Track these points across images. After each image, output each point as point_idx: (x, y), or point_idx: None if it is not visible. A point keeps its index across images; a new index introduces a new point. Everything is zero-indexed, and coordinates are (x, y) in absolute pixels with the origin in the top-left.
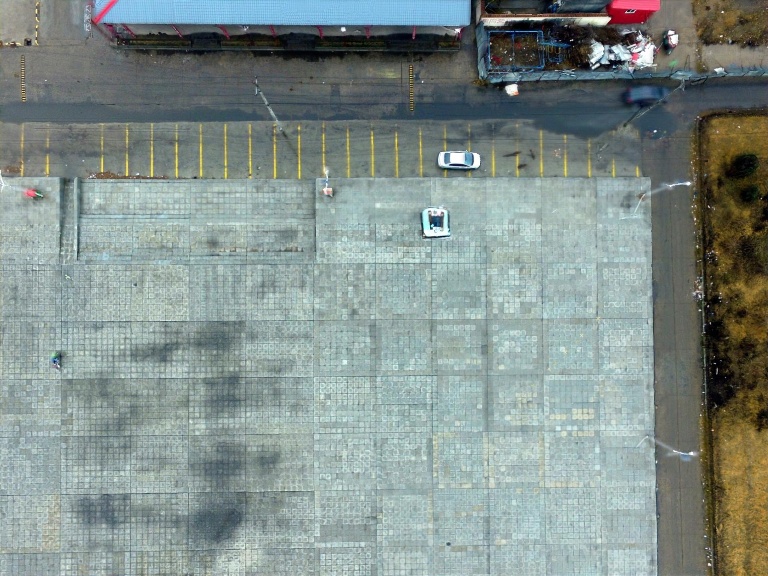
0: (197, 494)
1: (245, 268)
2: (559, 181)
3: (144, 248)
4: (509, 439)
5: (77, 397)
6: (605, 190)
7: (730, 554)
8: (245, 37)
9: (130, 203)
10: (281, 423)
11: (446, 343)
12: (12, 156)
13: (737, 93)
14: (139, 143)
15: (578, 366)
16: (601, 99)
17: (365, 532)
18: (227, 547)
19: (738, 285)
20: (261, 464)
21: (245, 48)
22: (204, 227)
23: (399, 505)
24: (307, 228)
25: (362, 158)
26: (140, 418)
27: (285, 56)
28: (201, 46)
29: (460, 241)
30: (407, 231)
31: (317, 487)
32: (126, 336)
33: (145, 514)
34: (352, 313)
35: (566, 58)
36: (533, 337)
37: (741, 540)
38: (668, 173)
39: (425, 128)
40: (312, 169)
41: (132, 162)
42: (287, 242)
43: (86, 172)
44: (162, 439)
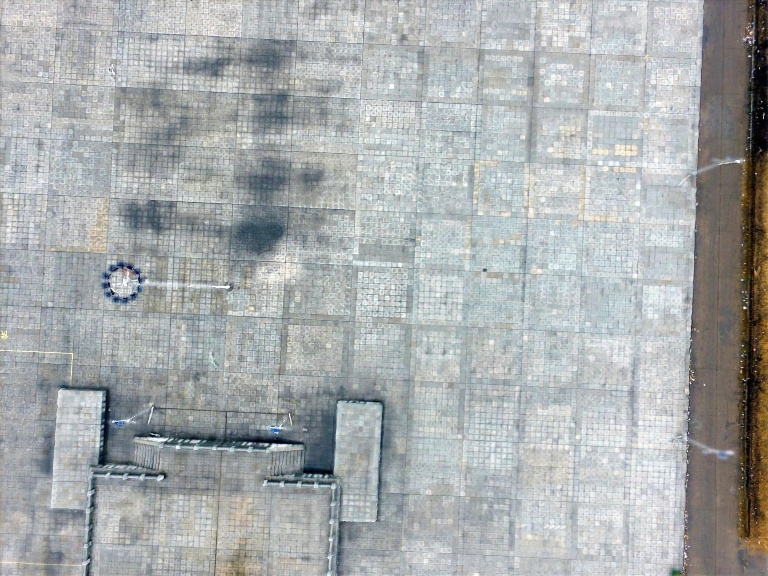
0: (241, 206)
1: None
2: None
3: None
4: (550, 171)
5: (130, 105)
6: None
7: (767, 297)
8: None
9: None
10: (326, 142)
11: (493, 73)
12: None
13: None
14: None
15: (623, 103)
16: None
17: (403, 253)
18: (268, 259)
19: None
20: (305, 181)
21: None
22: None
23: (438, 229)
24: None
25: None
26: (189, 129)
27: None
28: None
29: None
30: None
31: (358, 206)
32: (180, 49)
33: (190, 222)
34: (401, 38)
35: None
36: (580, 72)
37: None
38: None
39: None
40: None
41: None
42: None
43: None
44: (210, 151)
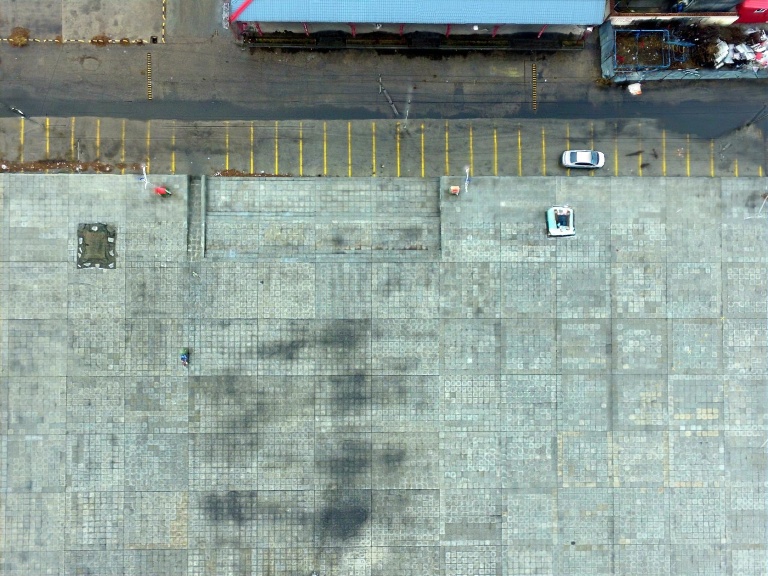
0: (323, 491)
1: (371, 266)
2: (684, 180)
3: (270, 246)
4: (633, 438)
5: (204, 394)
6: (730, 190)
7: None
8: (370, 35)
9: (255, 201)
10: (406, 421)
11: (571, 342)
12: (138, 153)
13: None
14: (264, 141)
15: (702, 366)
16: (724, 98)
17: (490, 530)
18: (353, 544)
19: None
20: (386, 462)
21: (369, 46)
22: (329, 225)
23: (524, 504)
24: (432, 226)
25: (485, 157)
26: (267, 415)
27: (409, 54)
28: (326, 44)
29: (585, 240)
30: (532, 230)
31: (442, 485)
32: (253, 333)
33: (272, 511)
34: (477, 311)
35: (689, 57)
36: (657, 336)
37: None
38: None
39: (548, 127)
40: (435, 167)
41: (257, 160)
42: (412, 240)
43: (211, 169)
44: (288, 436)
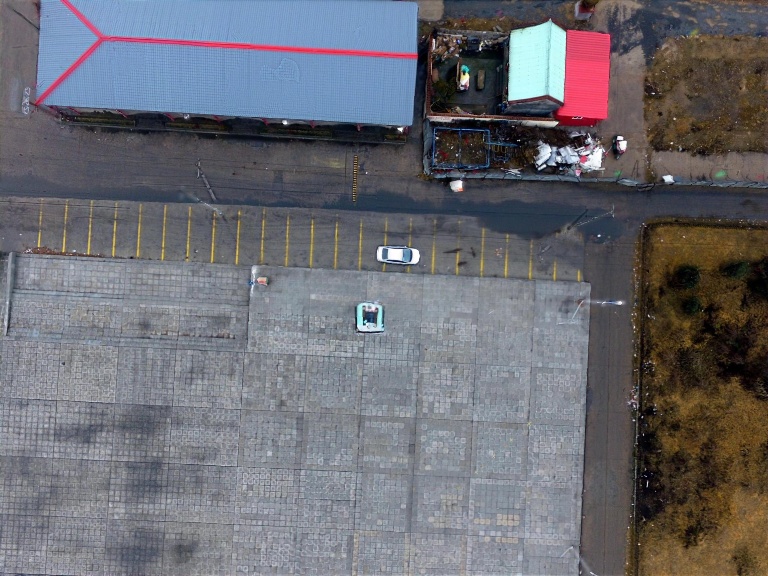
0: None
1: (175, 353)
2: (498, 282)
3: (75, 326)
4: (431, 541)
5: None
6: (544, 294)
7: None
8: (190, 119)
9: (64, 280)
10: (201, 512)
11: (373, 440)
12: None
13: (684, 202)
14: (78, 220)
15: (506, 471)
16: (546, 200)
17: None
18: None
19: (674, 398)
20: (179, 552)
21: (190, 130)
22: (137, 308)
23: None
24: (240, 315)
25: (301, 247)
26: (60, 498)
27: (230, 140)
28: (146, 126)
29: (394, 337)
30: (341, 324)
31: None
32: (51, 415)
33: None
34: (280, 404)
35: (513, 157)
36: (462, 439)
37: None
38: (610, 279)
39: (366, 220)
40: (250, 255)
41: (69, 238)
42: (219, 328)
43: (23, 246)
44: (80, 521)
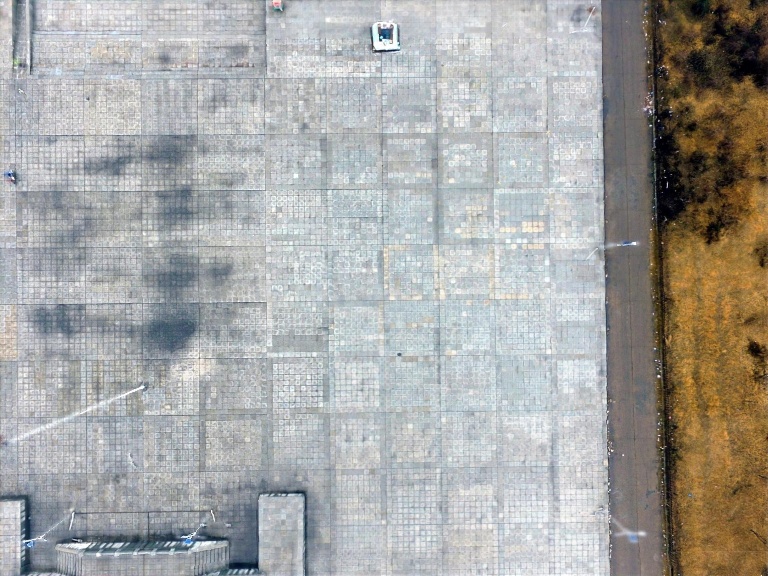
0: (151, 305)
1: (196, 82)
2: None
3: (96, 64)
4: (459, 252)
5: (32, 209)
6: (555, 4)
7: (679, 365)
8: None
9: (82, 20)
10: (233, 235)
11: (396, 157)
12: None
13: None
14: None
15: (528, 179)
16: None
17: (317, 343)
18: (181, 356)
19: (689, 99)
20: (214, 276)
21: None
22: (156, 43)
23: (350, 316)
24: (258, 44)
25: None
26: (94, 230)
27: None
28: None
29: (410, 55)
30: (357, 46)
31: (269, 298)
32: (79, 150)
33: (100, 324)
34: (303, 127)
35: None
36: (483, 151)
37: (690, 351)
38: None
39: None
40: None
41: None
42: (238, 58)
43: None
44: (116, 251)
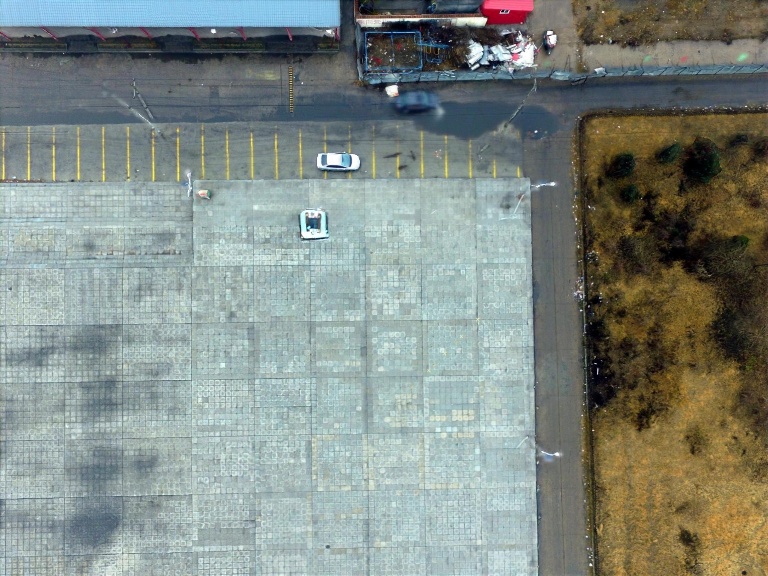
0: (73, 499)
1: (122, 271)
2: (438, 182)
3: (20, 252)
4: (389, 441)
5: None
6: (484, 191)
7: (611, 554)
8: (122, 39)
9: (6, 207)
10: (158, 427)
11: (325, 345)
12: None
13: (618, 93)
14: (16, 146)
15: (458, 367)
16: (482, 100)
17: (243, 535)
18: (104, 552)
19: (618, 285)
20: (138, 468)
21: (122, 50)
22: (81, 230)
23: (278, 508)
24: (185, 231)
25: (241, 160)
26: (15, 423)
27: (163, 58)
28: (78, 48)
29: (339, 243)
30: (285, 233)
31: (195, 491)
32: (1, 340)
33: (21, 519)
34: (230, 316)
35: (446, 59)
36: (412, 338)
37: (621, 540)
38: (549, 173)
39: (305, 130)
40: (191, 171)
41: (9, 165)
42: (165, 245)
43: None
44: (38, 444)
